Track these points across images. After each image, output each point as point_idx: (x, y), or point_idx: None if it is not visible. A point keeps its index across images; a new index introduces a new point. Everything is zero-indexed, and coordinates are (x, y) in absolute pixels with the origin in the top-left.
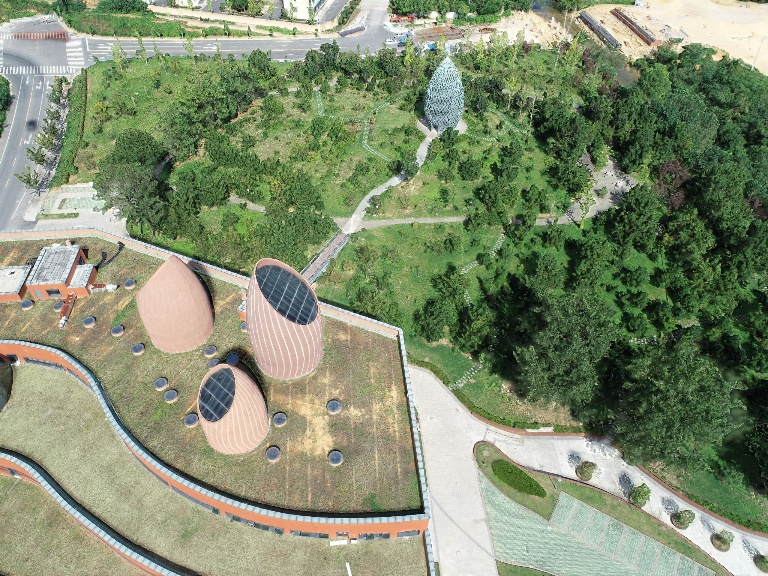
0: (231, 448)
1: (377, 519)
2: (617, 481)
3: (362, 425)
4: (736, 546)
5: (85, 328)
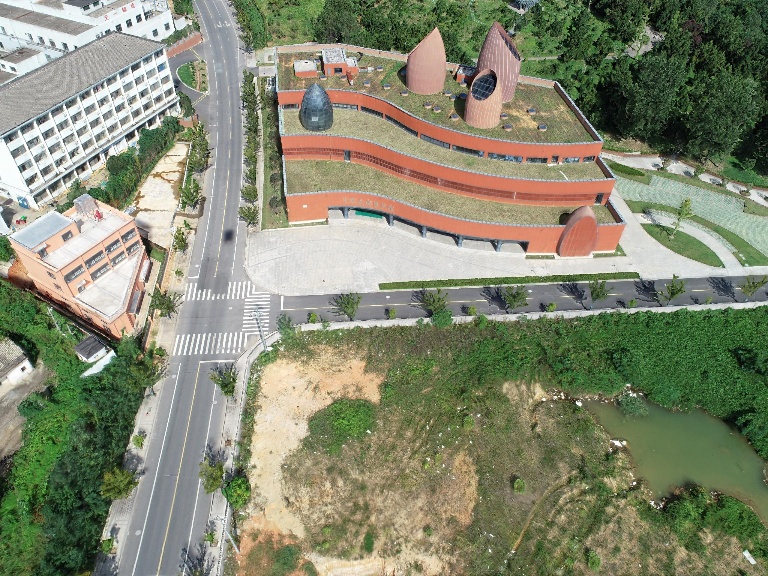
0: (486, 122)
1: (577, 143)
2: (682, 173)
3: (550, 118)
4: (754, 195)
5: (366, 87)
